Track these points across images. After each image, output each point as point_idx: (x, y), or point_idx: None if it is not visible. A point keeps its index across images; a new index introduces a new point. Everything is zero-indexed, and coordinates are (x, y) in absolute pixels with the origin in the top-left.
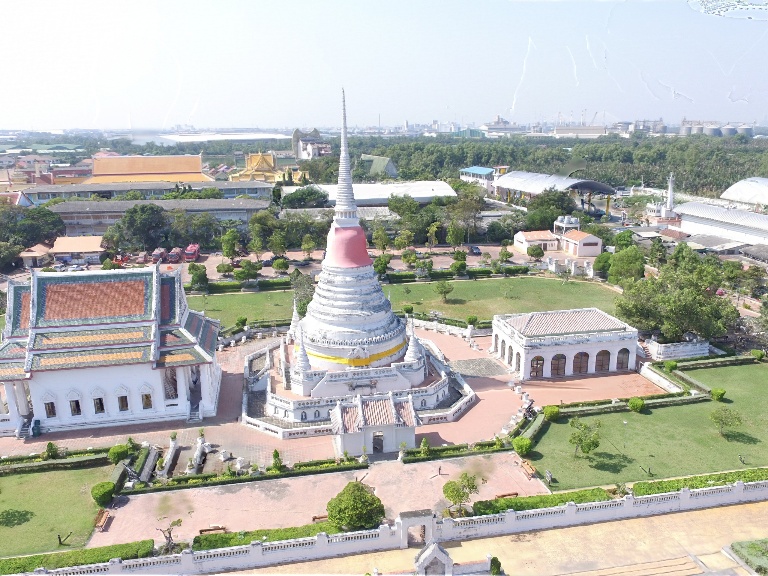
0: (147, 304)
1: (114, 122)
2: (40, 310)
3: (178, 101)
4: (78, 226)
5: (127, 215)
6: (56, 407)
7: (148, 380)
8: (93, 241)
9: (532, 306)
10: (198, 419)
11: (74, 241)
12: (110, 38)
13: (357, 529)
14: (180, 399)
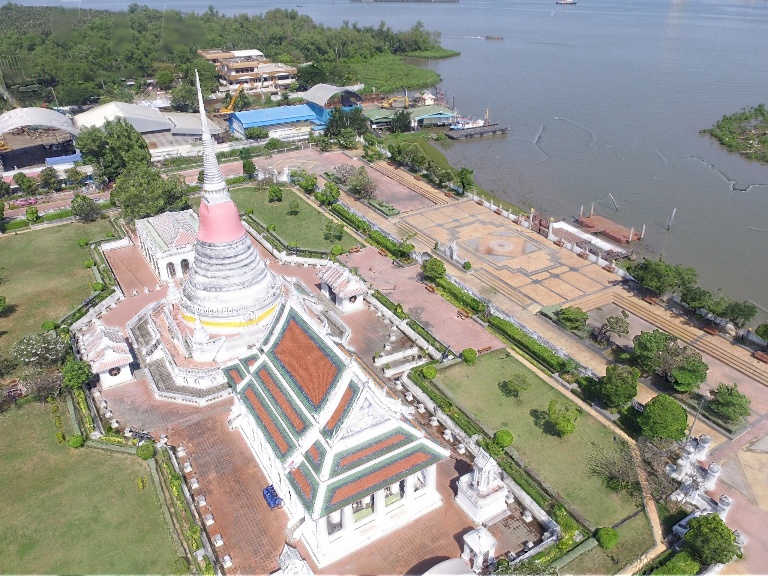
0: None
1: None
2: None
3: None
4: None
5: None
6: None
7: None
8: None
9: (38, 271)
10: None
11: None
12: None
13: (434, 278)
14: None
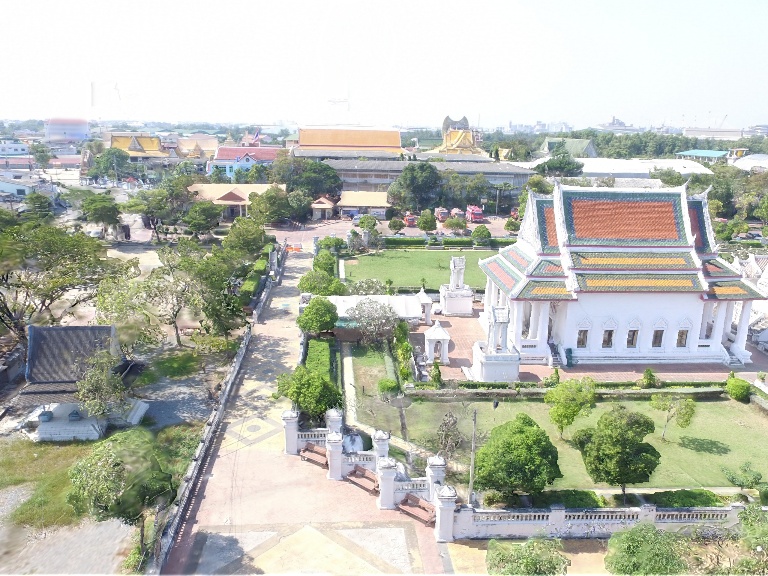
0: (679, 228)
1: (333, 91)
2: (569, 227)
3: (391, 72)
4: (344, 184)
5: (408, 172)
6: (589, 336)
7: (689, 314)
8: (378, 196)
9: None
10: (740, 364)
11: (360, 195)
12: (337, 6)
13: None
14: (716, 339)
